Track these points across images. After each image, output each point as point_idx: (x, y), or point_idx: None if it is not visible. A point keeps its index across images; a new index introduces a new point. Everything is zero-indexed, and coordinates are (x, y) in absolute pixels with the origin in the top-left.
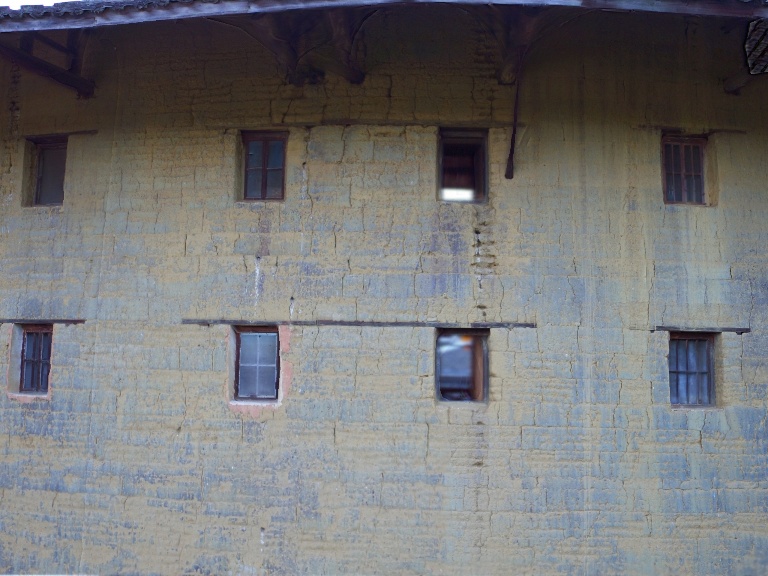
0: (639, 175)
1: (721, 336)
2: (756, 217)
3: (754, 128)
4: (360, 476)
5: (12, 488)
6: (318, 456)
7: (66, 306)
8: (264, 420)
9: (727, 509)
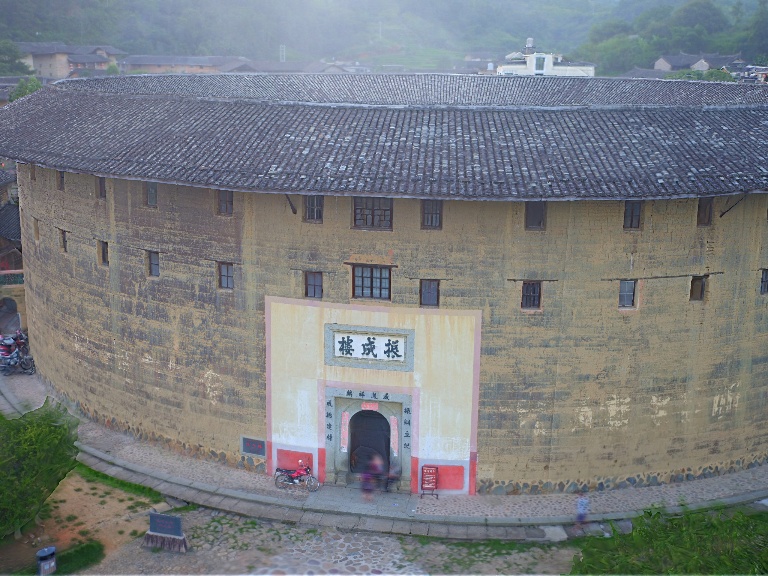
0: (761, 212)
1: None
2: None
3: None
4: (664, 332)
5: (525, 347)
6: (650, 327)
7: (550, 274)
8: (632, 315)
9: None
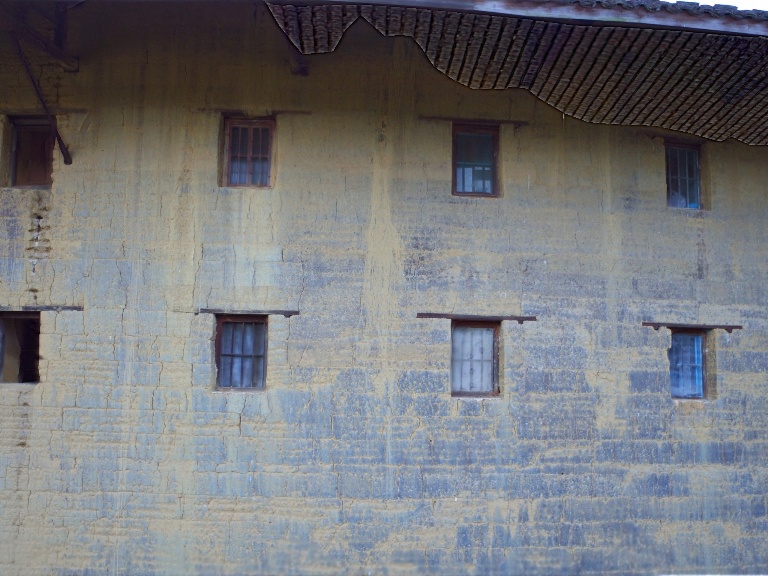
0: (194, 158)
1: (268, 319)
2: (315, 199)
3: (320, 109)
4: None
5: None
6: None
7: None
8: None
9: (263, 493)
